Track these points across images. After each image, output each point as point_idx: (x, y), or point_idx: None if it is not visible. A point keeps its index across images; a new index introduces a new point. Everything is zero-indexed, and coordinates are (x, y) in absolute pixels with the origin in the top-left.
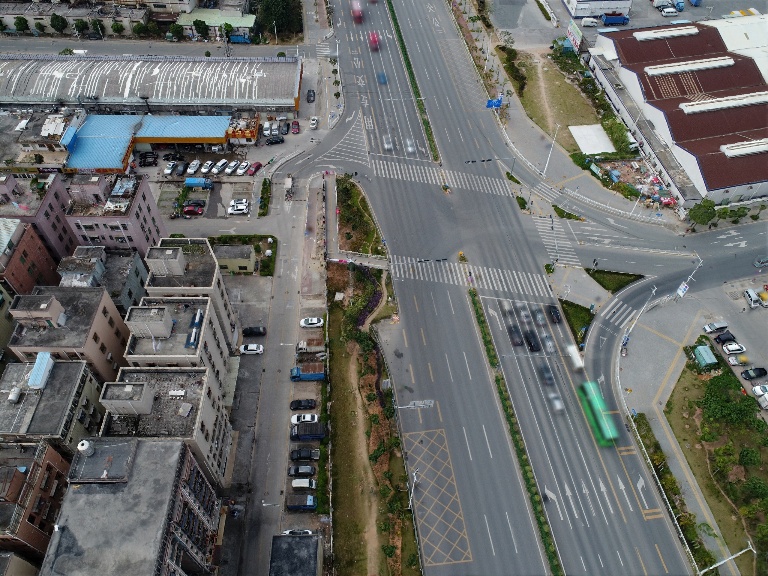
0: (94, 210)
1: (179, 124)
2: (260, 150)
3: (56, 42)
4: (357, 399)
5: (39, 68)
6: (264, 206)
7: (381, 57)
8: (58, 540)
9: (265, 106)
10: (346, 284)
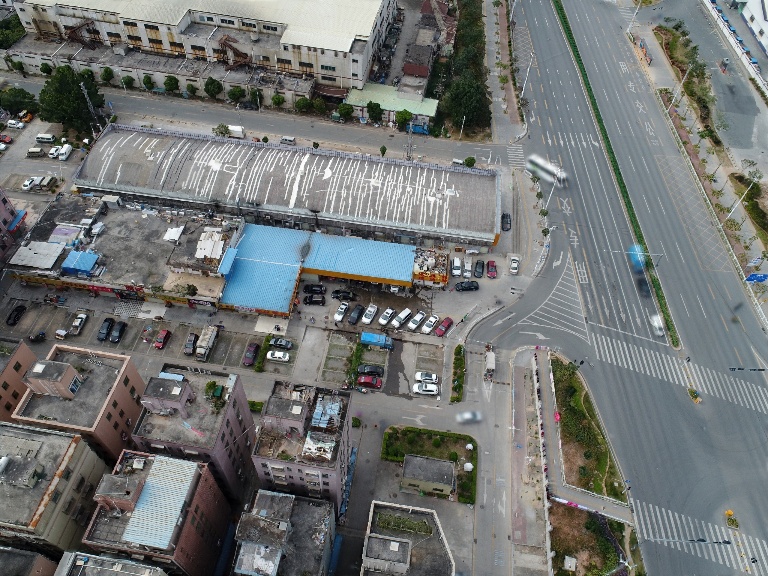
0: (287, 445)
1: (354, 252)
2: (449, 297)
3: (207, 108)
4: None
5: (193, 153)
6: (459, 388)
7: (588, 173)
8: None
9: (457, 237)
10: (579, 545)
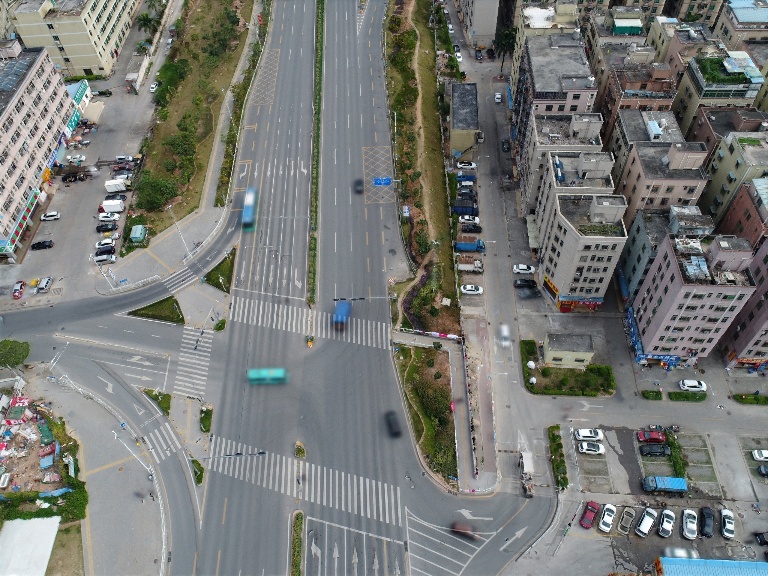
0: None
1: None
2: (594, 569)
3: None
4: (429, 217)
5: None
6: (555, 436)
7: None
8: (584, 61)
9: None
10: (440, 311)
